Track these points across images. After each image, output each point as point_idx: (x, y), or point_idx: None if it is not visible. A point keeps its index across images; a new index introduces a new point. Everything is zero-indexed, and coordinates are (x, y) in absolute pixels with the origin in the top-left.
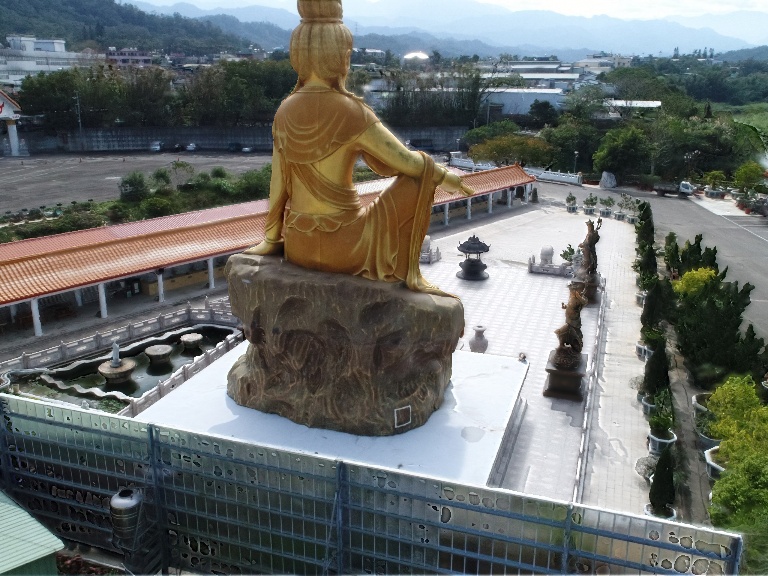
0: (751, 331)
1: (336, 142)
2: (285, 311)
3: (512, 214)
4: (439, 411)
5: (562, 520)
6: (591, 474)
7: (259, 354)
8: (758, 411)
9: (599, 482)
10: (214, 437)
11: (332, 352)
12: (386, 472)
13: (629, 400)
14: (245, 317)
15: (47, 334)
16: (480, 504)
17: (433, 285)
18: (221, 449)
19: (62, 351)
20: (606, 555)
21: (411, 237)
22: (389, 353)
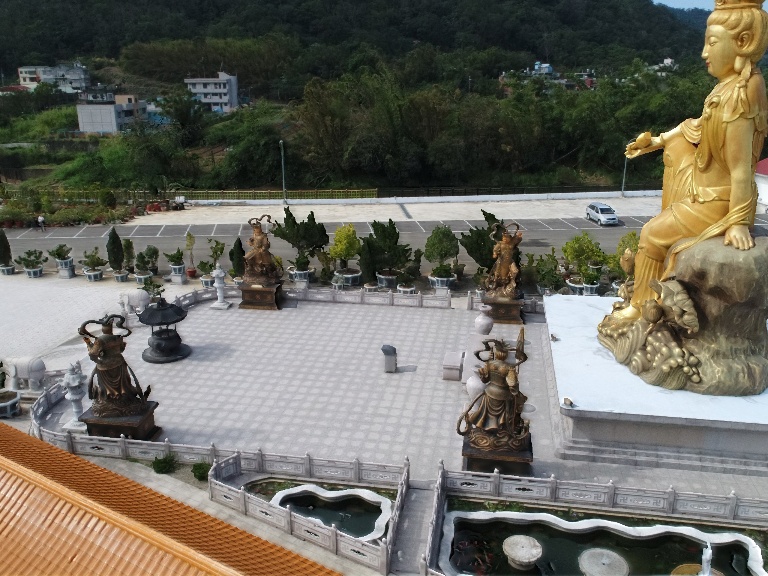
0: None
1: None
2: None
3: None
4: None
5: None
6: None
7: None
8: None
9: None
10: None
11: None
12: None
13: None
14: None
15: None
16: None
17: None
18: None
19: None
20: None
21: None
22: None
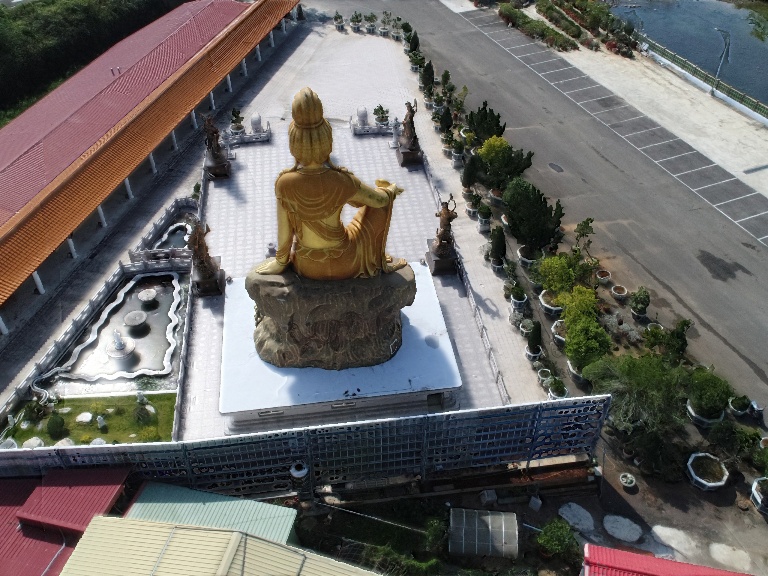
0: (545, 202)
1: (338, 206)
2: (314, 312)
3: (293, 45)
4: (403, 329)
5: (535, 408)
6: (486, 332)
7: (290, 336)
8: (578, 288)
9: (493, 336)
10: (350, 425)
11: (346, 325)
12: (452, 414)
13: (481, 261)
14: (283, 320)
15: (12, 329)
16: (498, 413)
17: (388, 257)
18: (352, 428)
19: (57, 347)
20: (555, 415)
21: (383, 242)
22: (386, 318)
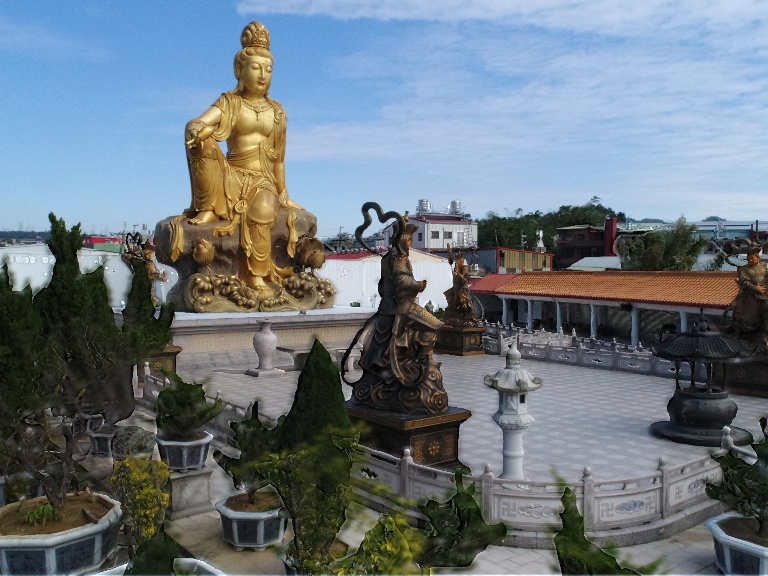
0: None
1: None
2: None
3: None
4: None
5: None
6: None
7: None
8: None
9: None
10: None
11: None
12: None
13: None
14: None
15: None
16: None
17: None
18: None
19: None
20: None
21: None
22: None
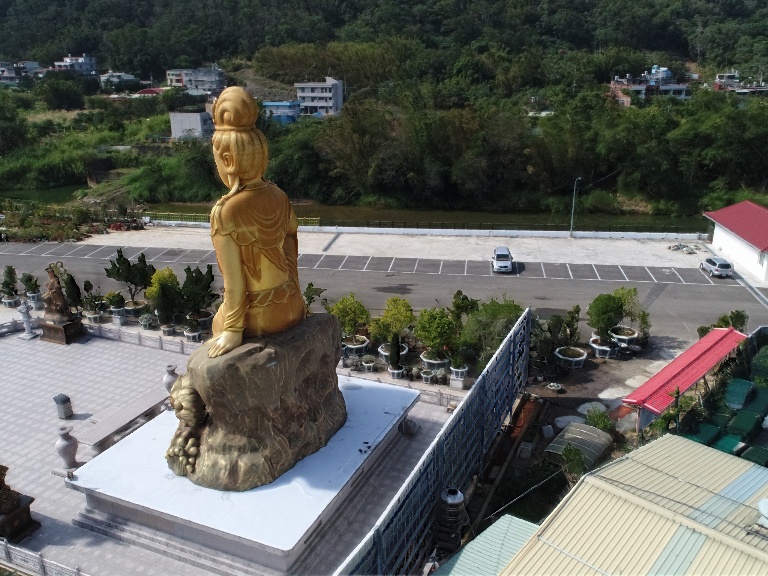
0: None
1: None
2: None
3: None
4: None
5: (508, 341)
6: None
7: (273, 426)
8: (392, 299)
9: None
10: None
11: None
12: None
13: None
14: (275, 396)
15: None
16: None
17: None
18: None
19: None
20: None
21: None
22: (337, 358)
